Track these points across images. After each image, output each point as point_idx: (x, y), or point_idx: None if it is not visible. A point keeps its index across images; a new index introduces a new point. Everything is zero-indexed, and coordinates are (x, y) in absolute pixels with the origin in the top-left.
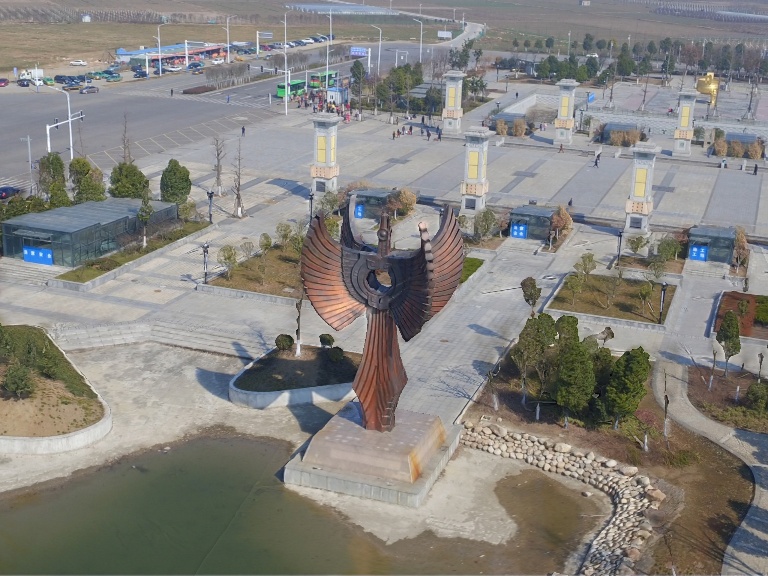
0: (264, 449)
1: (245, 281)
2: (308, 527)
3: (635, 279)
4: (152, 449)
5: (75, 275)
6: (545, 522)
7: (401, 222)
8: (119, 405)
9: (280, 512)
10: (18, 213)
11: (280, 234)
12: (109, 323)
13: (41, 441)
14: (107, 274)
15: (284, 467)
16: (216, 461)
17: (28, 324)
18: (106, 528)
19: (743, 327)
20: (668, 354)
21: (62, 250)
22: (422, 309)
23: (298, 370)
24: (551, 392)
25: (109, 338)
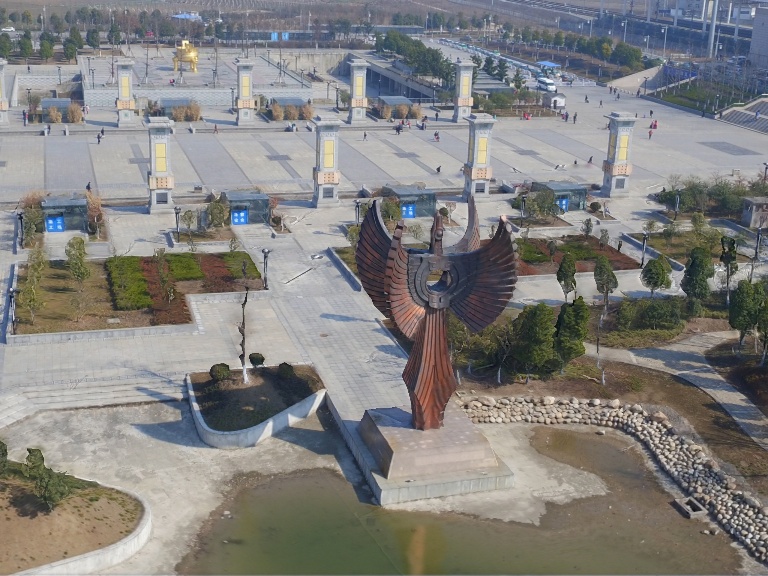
0: (314, 482)
1: (53, 322)
2: (460, 536)
3: None
4: (214, 519)
5: None
6: (607, 465)
7: (107, 228)
8: None
9: (417, 532)
10: None
11: None
12: None
13: (116, 549)
14: None
15: (380, 490)
16: (289, 508)
17: None
18: None
19: (524, 268)
20: None
21: None
22: (499, 299)
23: (261, 396)
24: (517, 354)
25: None
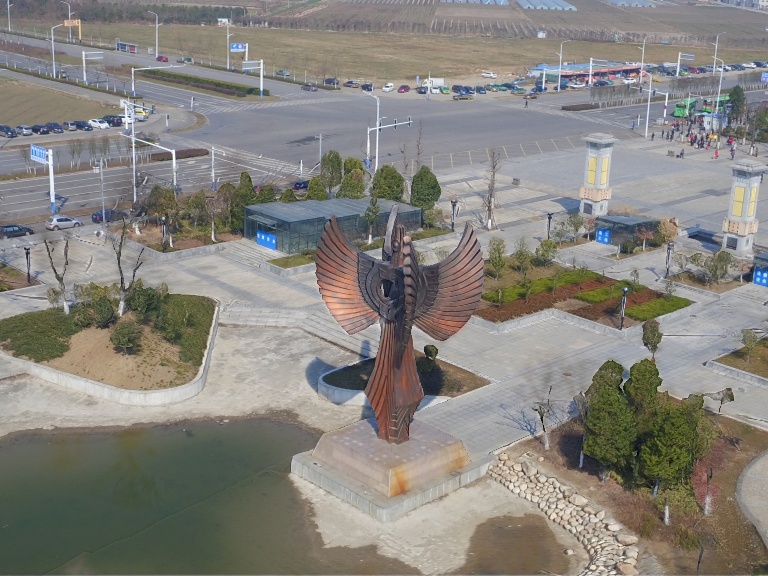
0: (305, 439)
1: None
2: (272, 514)
3: None
4: (213, 419)
5: (285, 261)
6: (497, 567)
7: (646, 253)
8: (222, 377)
9: (263, 496)
10: (265, 200)
11: None
12: (276, 306)
13: (123, 392)
14: (313, 264)
15: (292, 457)
16: (255, 440)
17: (211, 296)
18: (116, 474)
19: None
20: None
21: (283, 237)
22: None
23: None
24: None
25: (265, 319)
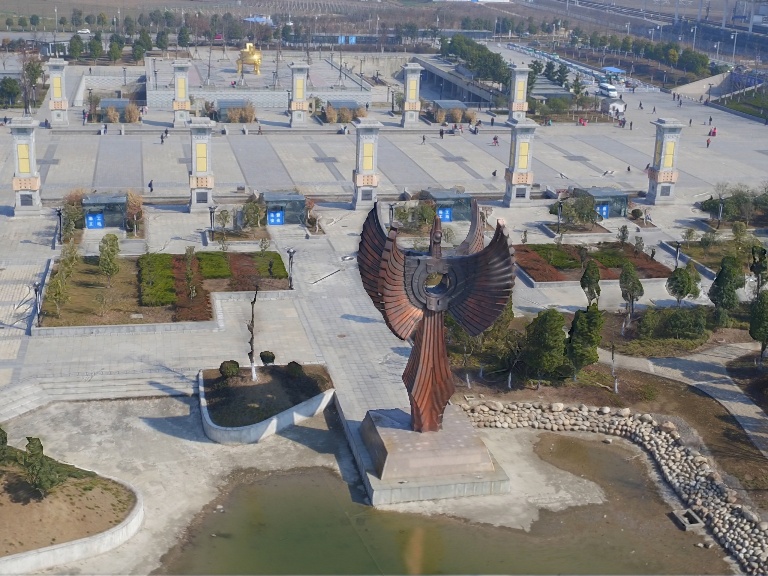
0: (310, 480)
1: (78, 315)
2: (447, 539)
3: (421, 247)
4: (206, 512)
5: None
6: (609, 473)
7: (146, 226)
8: None
9: (405, 534)
10: None
11: (67, 258)
12: None
13: (103, 538)
14: None
15: (372, 490)
16: (282, 505)
17: None
18: None
19: (553, 273)
20: (525, 308)
21: None
22: (497, 303)
23: (268, 394)
24: (527, 360)
25: (6, 409)
